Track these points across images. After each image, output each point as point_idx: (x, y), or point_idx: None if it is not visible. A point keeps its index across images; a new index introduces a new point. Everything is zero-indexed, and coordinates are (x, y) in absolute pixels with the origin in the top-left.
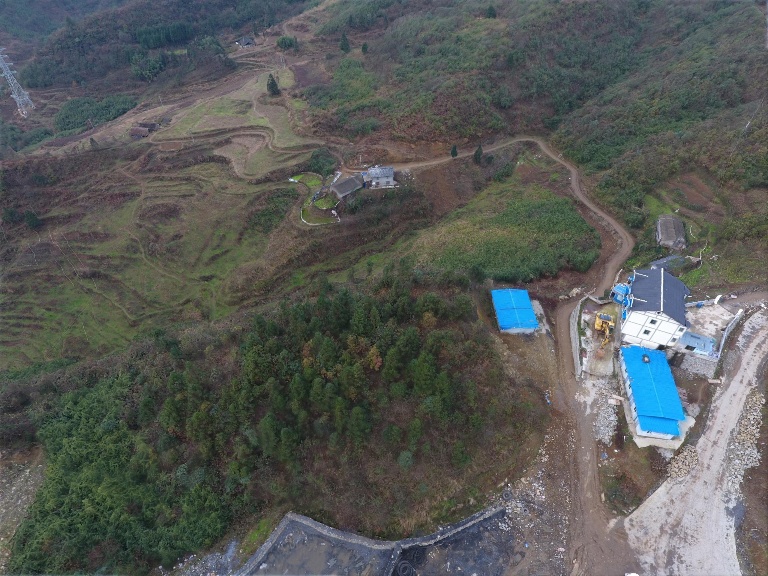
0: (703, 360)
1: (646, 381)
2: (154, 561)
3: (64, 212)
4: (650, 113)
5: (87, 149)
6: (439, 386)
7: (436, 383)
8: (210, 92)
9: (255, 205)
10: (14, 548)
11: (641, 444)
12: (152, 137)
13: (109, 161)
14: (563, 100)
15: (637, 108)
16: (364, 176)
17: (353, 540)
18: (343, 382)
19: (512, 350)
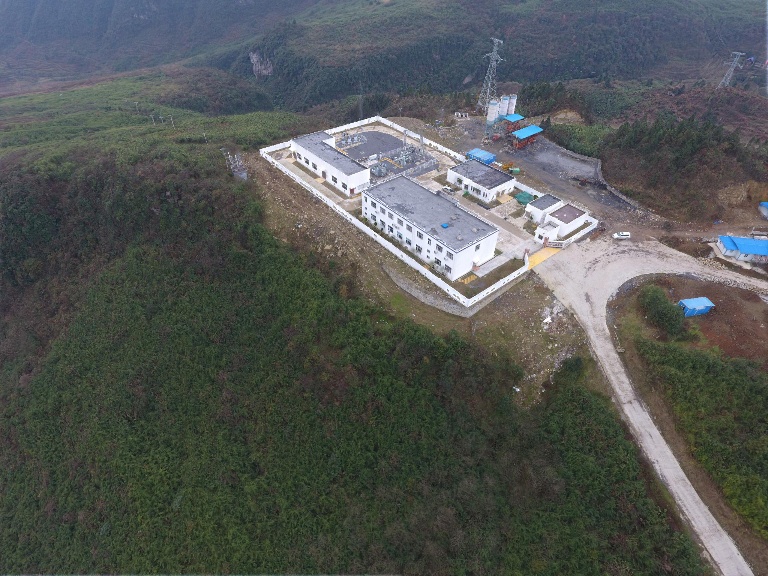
0: None
1: (763, 244)
2: (567, 147)
3: (730, 129)
4: None
5: None
6: None
7: None
8: None
9: None
10: None
11: (710, 244)
12: None
13: None
14: None
15: None
16: None
17: None
18: None
19: (745, 210)
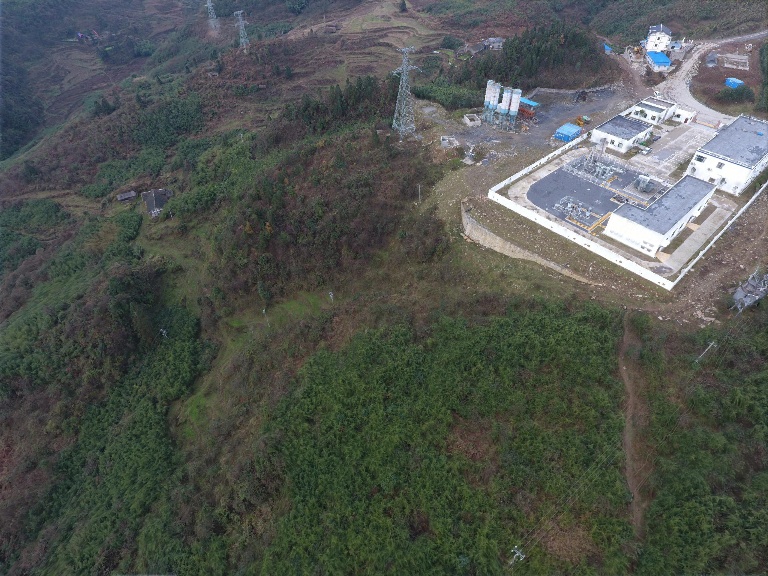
0: (678, 52)
1: None
2: None
3: (303, 70)
4: (648, 3)
5: (305, 37)
6: (588, 42)
7: (587, 42)
8: (346, 17)
9: (417, 64)
10: (444, 100)
11: (656, 71)
12: (340, 32)
13: (321, 43)
14: (593, 6)
15: (640, 1)
16: (485, 43)
17: (563, 90)
18: (553, 45)
19: None
